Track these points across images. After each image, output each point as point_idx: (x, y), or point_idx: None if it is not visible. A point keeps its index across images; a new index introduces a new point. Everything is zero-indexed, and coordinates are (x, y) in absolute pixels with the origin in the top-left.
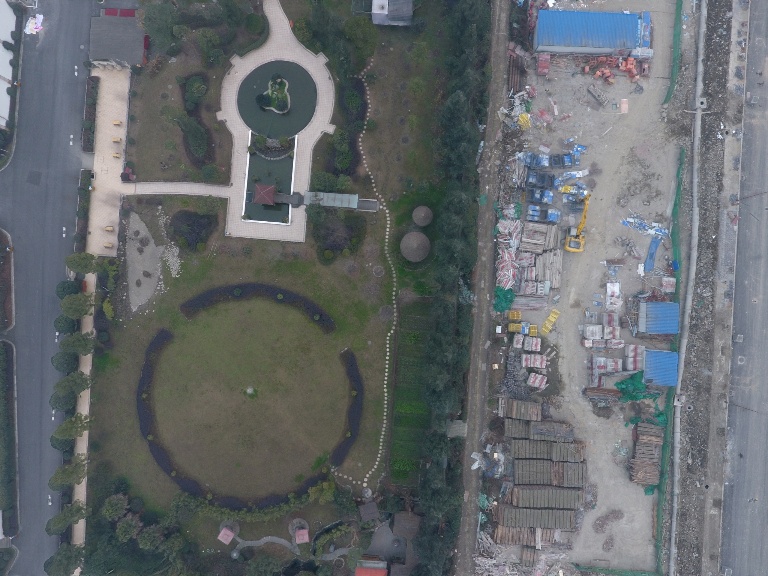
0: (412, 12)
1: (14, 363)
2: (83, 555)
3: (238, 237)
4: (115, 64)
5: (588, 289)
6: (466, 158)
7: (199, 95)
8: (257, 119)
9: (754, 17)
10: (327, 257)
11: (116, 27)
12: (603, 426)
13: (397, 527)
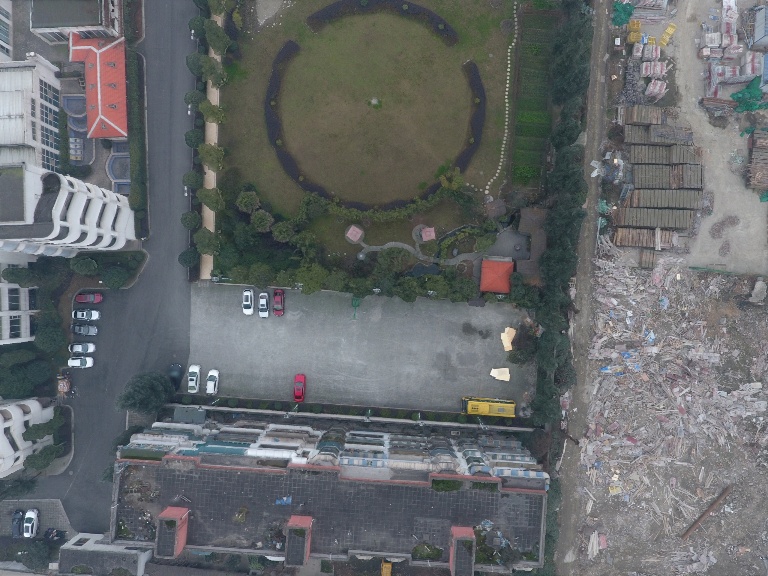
0: None
1: (144, 74)
2: (220, 240)
3: None
4: None
5: (704, 4)
6: None
7: None
8: None
9: None
10: None
11: None
12: (719, 136)
13: (524, 219)
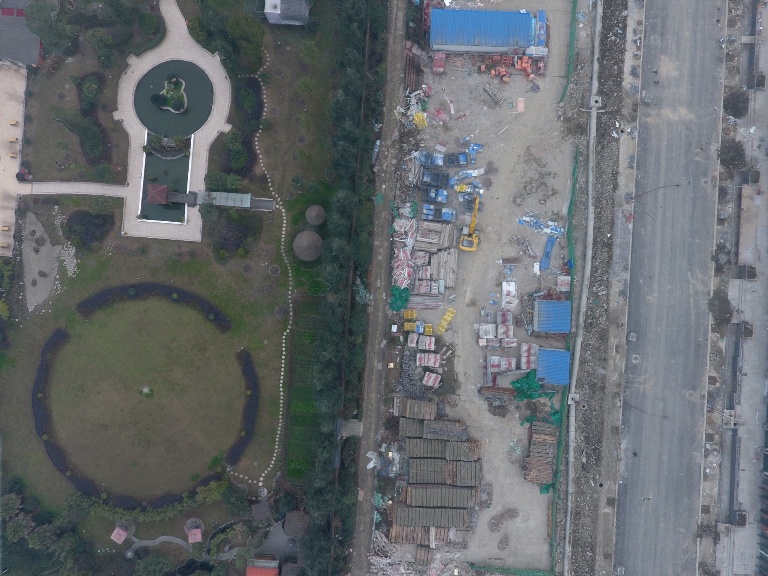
0: (305, 11)
1: None
2: None
3: (134, 237)
4: (10, 64)
5: (484, 288)
6: (350, 157)
7: (90, 95)
8: (154, 119)
9: (650, 15)
10: (222, 256)
11: (13, 27)
12: (499, 425)
13: (288, 526)
